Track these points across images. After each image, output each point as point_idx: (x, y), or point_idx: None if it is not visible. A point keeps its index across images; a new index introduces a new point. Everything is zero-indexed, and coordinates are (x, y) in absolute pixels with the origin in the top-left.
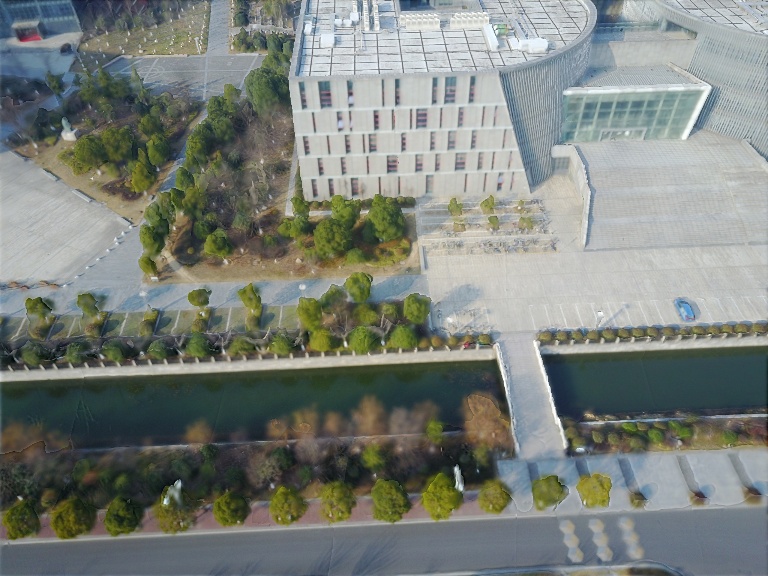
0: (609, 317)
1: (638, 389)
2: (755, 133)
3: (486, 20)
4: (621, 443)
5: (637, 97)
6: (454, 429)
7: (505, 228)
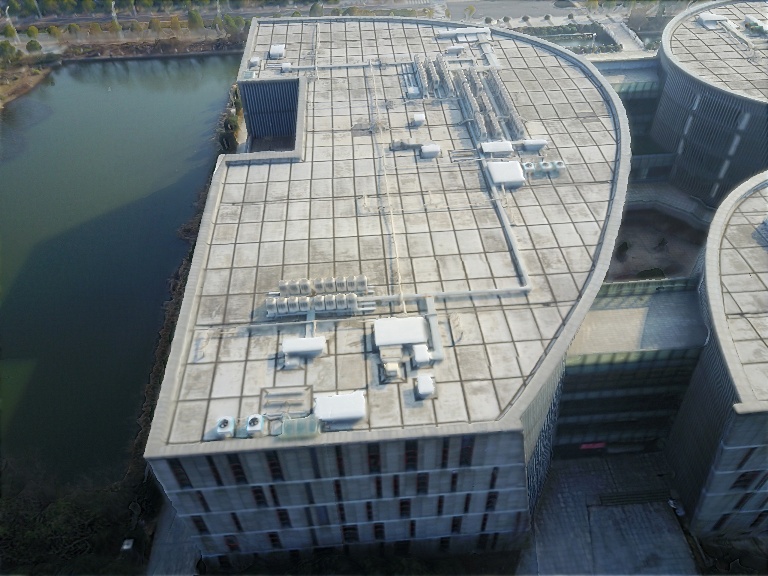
0: None
1: None
2: None
3: None
4: None
5: None
6: (650, 35)
7: None
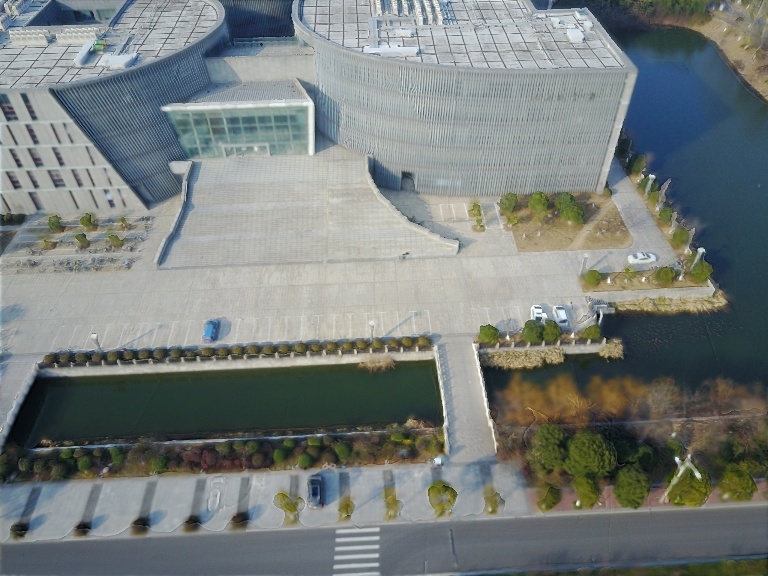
0: (133, 338)
1: (131, 413)
2: (375, 149)
3: (92, 36)
4: (43, 471)
5: (244, 113)
6: None
7: (96, 246)
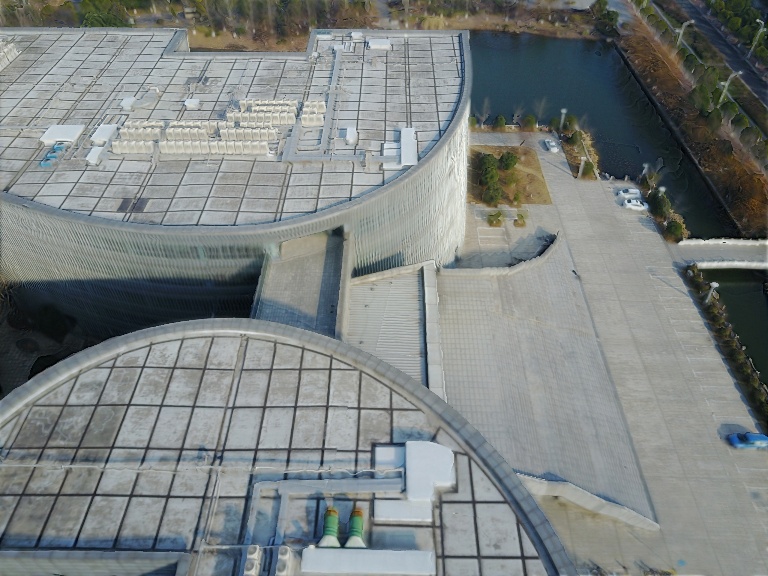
0: None
1: None
2: (440, 256)
3: (288, 558)
4: None
5: None
6: None
7: None
